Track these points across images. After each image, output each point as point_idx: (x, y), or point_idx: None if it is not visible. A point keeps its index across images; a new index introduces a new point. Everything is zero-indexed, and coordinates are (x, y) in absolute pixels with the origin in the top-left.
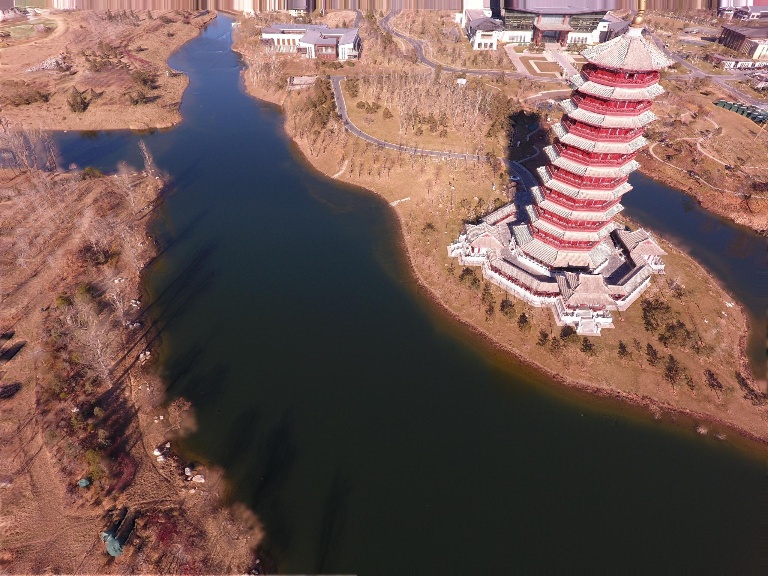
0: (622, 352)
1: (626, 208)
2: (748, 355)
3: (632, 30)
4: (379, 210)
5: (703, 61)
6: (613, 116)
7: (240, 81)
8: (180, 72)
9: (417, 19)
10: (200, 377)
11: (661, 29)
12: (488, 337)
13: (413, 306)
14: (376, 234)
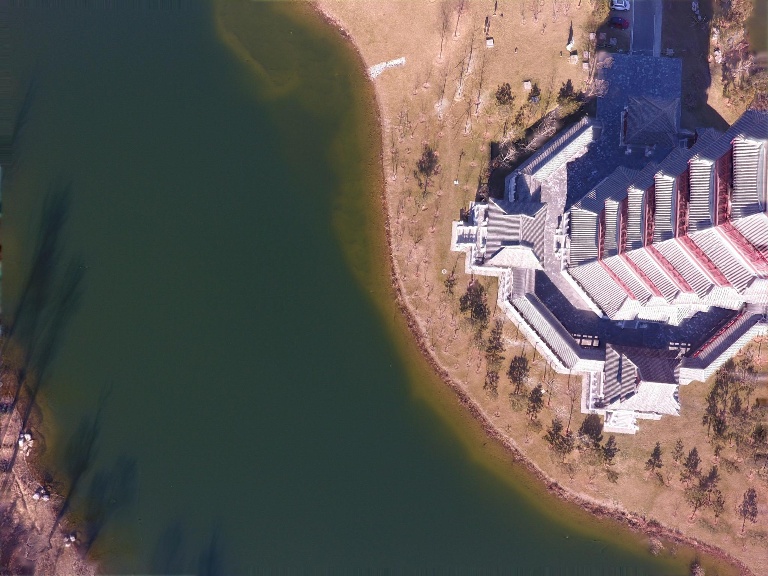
0: (653, 462)
1: None
2: None
3: None
4: (347, 87)
5: None
6: None
7: None
8: None
9: None
10: (105, 476)
11: None
12: (481, 415)
13: (385, 343)
14: (339, 160)
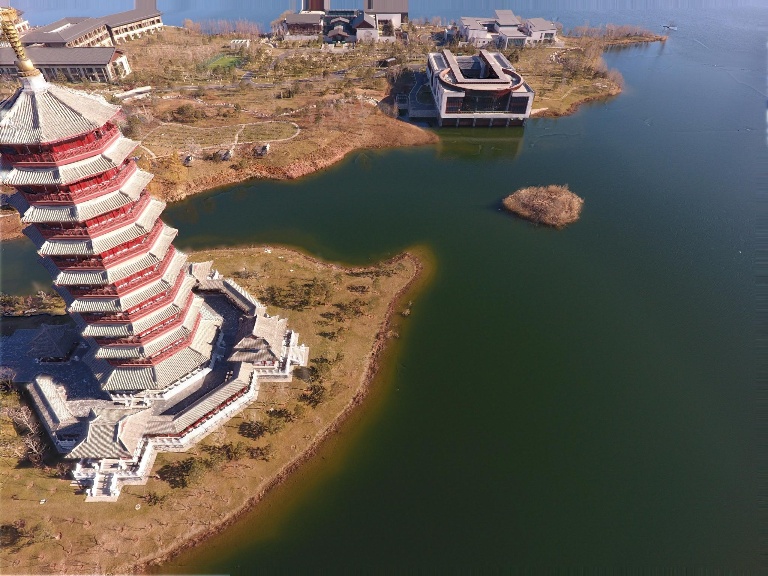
0: (330, 337)
1: None
2: (325, 262)
3: (34, 80)
4: None
5: None
6: (124, 185)
7: None
8: None
9: None
10: None
11: None
12: (295, 463)
13: (211, 575)
14: None
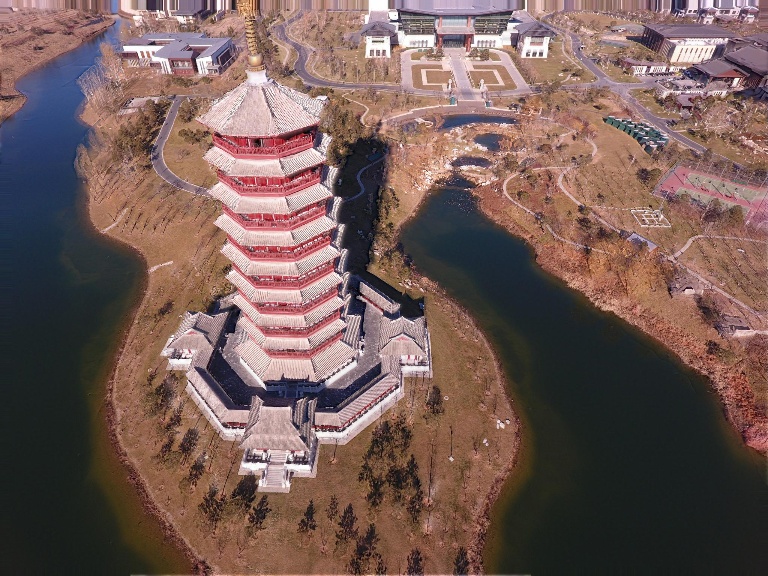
0: (305, 522)
1: (443, 267)
2: (495, 514)
3: (249, 74)
4: (131, 278)
5: (614, 66)
6: (252, 197)
7: (81, 103)
8: (18, 94)
9: (320, 23)
10: None
11: (587, 28)
12: (145, 492)
13: (82, 435)
14: (106, 315)
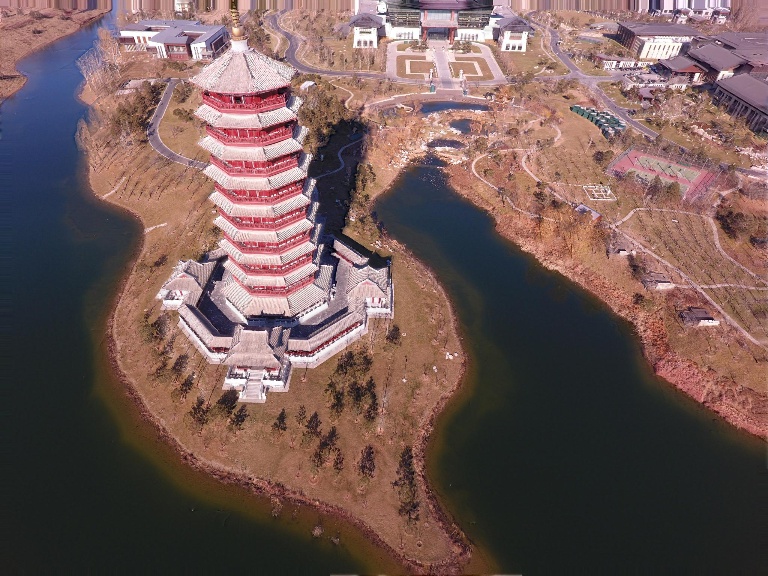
0: (278, 424)
1: (412, 232)
2: (438, 423)
3: (233, 43)
4: (129, 238)
5: (587, 60)
6: (235, 147)
7: (80, 84)
8: (18, 74)
9: None
10: None
11: (568, 25)
12: (142, 403)
13: (86, 361)
14: (107, 268)
